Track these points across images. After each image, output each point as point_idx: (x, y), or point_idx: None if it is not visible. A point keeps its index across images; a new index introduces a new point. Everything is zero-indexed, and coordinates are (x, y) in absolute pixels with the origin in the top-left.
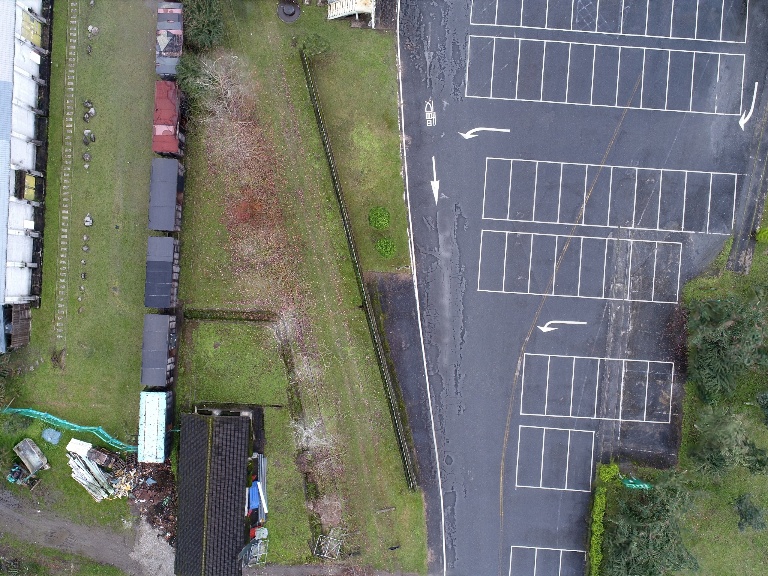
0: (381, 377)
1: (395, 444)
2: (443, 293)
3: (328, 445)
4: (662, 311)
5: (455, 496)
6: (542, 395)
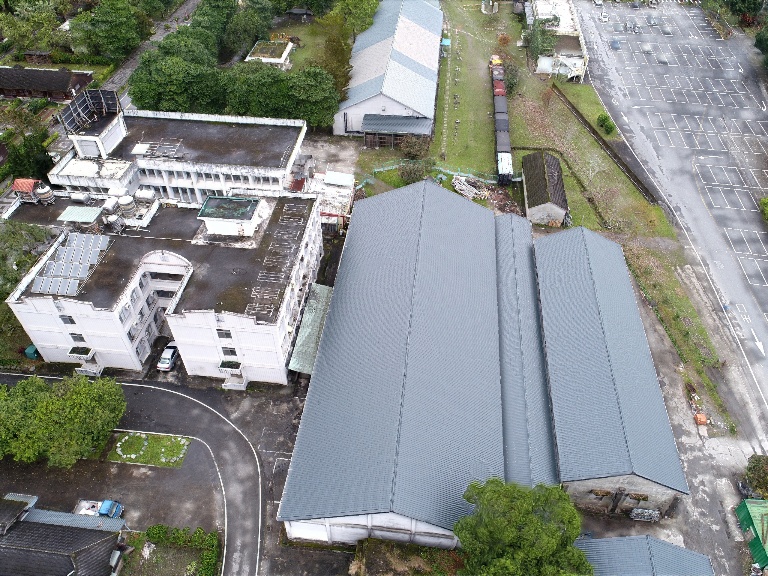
0: (620, 168)
1: (636, 190)
2: (642, 145)
3: (597, 190)
4: (760, 156)
5: (680, 208)
6: (712, 177)
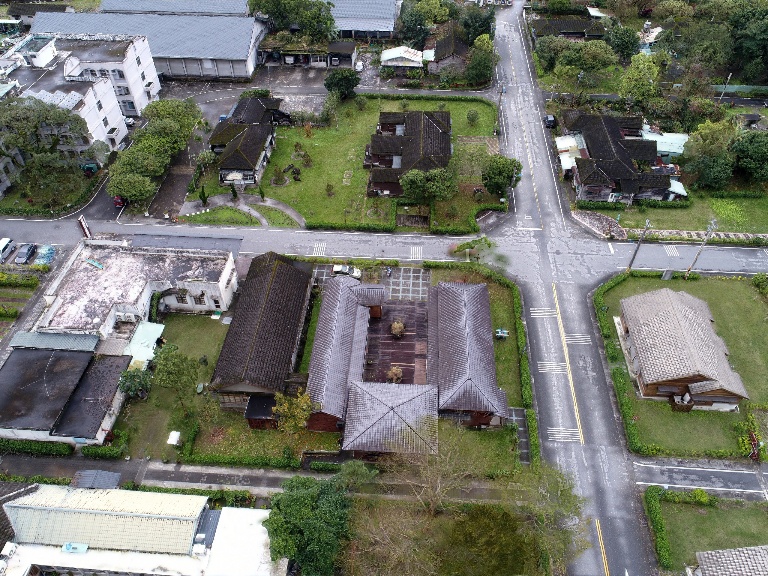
0: (34, 3)
1: None
2: None
3: None
4: None
5: None
6: None
